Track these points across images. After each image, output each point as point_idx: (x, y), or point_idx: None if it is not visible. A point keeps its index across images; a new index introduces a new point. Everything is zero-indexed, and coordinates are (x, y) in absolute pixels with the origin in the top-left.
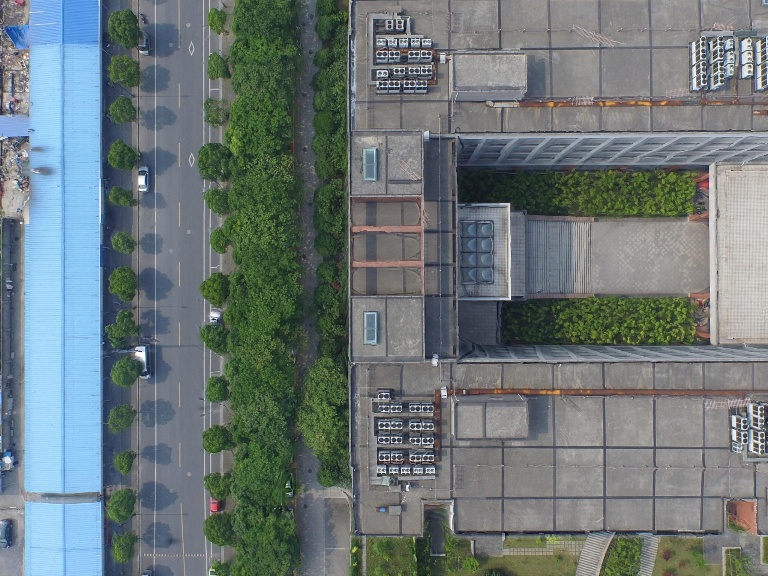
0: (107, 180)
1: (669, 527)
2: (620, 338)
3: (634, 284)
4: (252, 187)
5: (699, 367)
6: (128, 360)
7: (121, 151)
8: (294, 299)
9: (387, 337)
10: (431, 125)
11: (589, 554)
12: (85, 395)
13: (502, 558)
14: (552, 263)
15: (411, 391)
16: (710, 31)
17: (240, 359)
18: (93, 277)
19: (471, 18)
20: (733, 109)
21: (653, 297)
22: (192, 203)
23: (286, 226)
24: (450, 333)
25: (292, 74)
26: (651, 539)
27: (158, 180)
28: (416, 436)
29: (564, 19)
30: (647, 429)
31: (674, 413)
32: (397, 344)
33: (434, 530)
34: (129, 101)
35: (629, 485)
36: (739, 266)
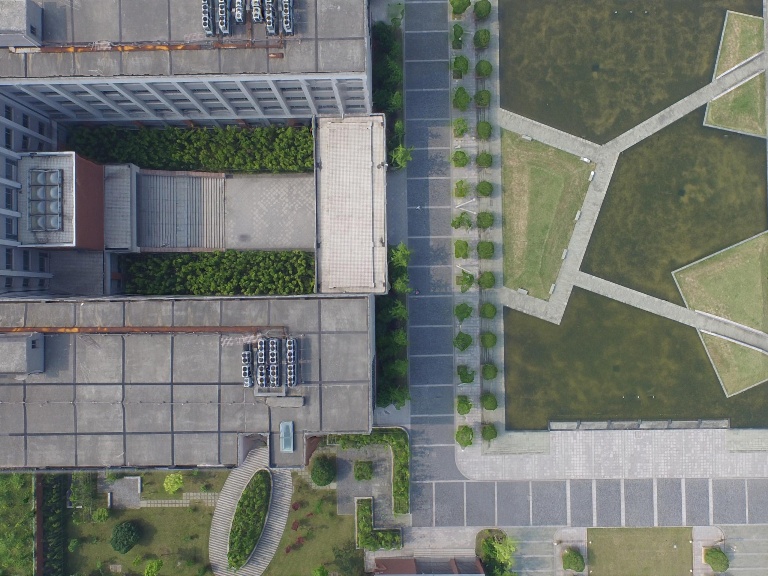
0: None
1: (188, 462)
2: (239, 290)
3: (268, 239)
4: None
5: (217, 305)
6: None
7: None
8: None
9: None
10: None
11: (224, 505)
12: None
13: (139, 510)
14: (180, 218)
15: None
16: None
17: None
18: None
19: None
20: (249, 52)
21: None
22: None
23: None
24: None
25: None
26: (285, 490)
27: None
28: None
29: None
30: (165, 366)
31: (191, 350)
32: None
33: (71, 482)
34: None
35: (148, 421)
36: (339, 216)
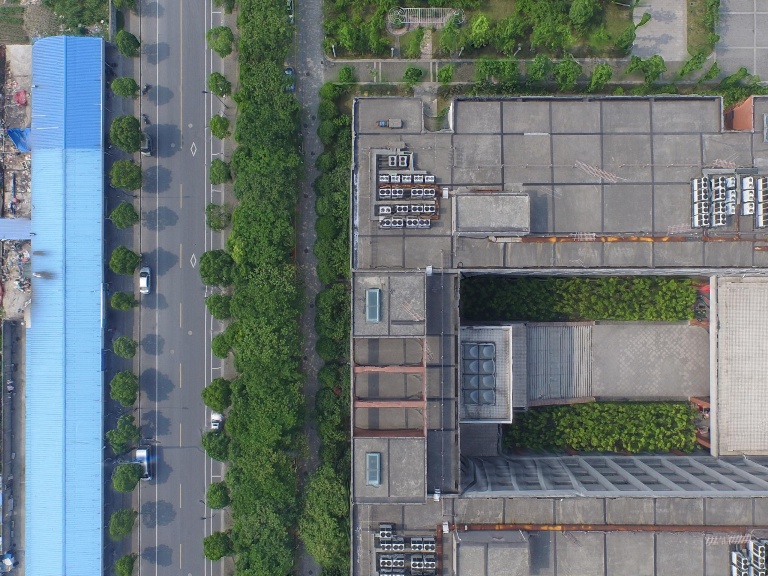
0: (109, 283)
1: None
2: (621, 445)
3: (635, 387)
4: (254, 297)
5: (700, 502)
6: (129, 465)
7: (123, 258)
8: (296, 409)
9: (389, 478)
10: (434, 260)
11: None
12: (86, 500)
13: None
14: (553, 368)
15: (413, 525)
16: (712, 168)
17: (241, 469)
18: (94, 381)
19: (474, 153)
20: (734, 245)
21: (653, 400)
22: (194, 305)
23: (288, 337)
24: (452, 467)
25: (294, 183)
26: None
27: (160, 281)
28: (418, 575)
29: (567, 154)
30: (648, 564)
31: (675, 548)
32: (399, 485)
33: None
34: (131, 207)
35: None
36: (739, 378)
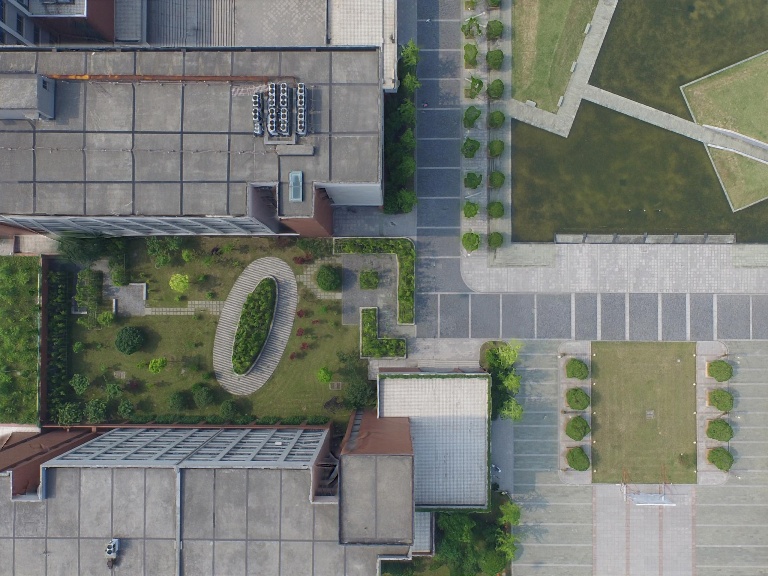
0: None
1: (197, 212)
2: None
3: None
4: None
5: (228, 56)
6: None
7: None
8: None
9: None
10: None
11: (229, 313)
12: None
13: (144, 317)
14: (189, 23)
15: None
16: None
17: None
18: None
19: None
20: None
21: None
22: None
23: None
24: None
25: None
26: (290, 299)
27: None
28: None
29: None
30: (175, 115)
31: (202, 99)
32: None
33: None
34: None
35: (157, 170)
36: (350, 12)
